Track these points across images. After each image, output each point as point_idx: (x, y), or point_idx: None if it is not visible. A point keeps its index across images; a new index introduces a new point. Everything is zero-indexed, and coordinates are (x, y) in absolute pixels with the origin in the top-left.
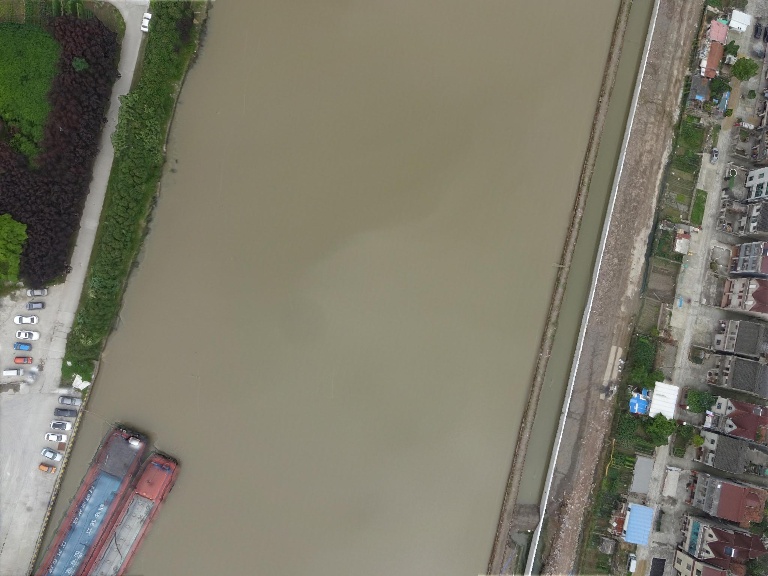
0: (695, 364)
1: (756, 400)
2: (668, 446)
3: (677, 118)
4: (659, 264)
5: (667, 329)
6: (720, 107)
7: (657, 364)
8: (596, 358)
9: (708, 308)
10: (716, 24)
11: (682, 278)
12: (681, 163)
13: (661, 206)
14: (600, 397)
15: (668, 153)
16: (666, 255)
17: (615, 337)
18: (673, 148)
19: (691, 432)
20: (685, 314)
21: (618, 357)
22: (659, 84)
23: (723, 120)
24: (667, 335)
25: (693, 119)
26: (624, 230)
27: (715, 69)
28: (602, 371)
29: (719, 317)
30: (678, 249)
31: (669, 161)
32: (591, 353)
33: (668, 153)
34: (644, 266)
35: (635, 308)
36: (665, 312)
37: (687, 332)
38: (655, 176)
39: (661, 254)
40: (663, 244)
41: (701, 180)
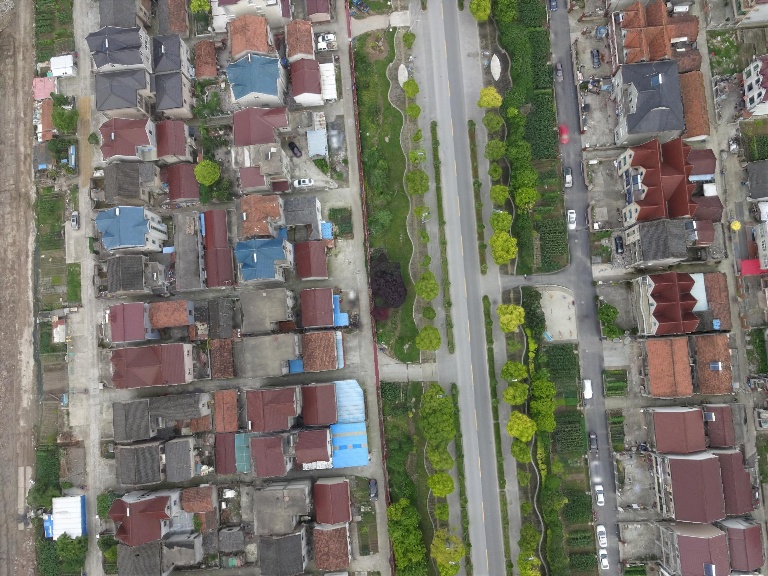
0: (112, 459)
1: (203, 477)
2: (101, 563)
3: (35, 195)
4: (49, 361)
5: (68, 431)
6: (69, 166)
7: (59, 475)
8: (5, 486)
9: (113, 391)
10: (39, 81)
11: (72, 368)
12: (46, 243)
13: (39, 296)
14: (19, 528)
15: (34, 237)
16: (49, 349)
17: (20, 457)
18: (38, 229)
19: (111, 543)
20: (85, 407)
21: (28, 478)
22: (7, 169)
23: (80, 177)
24: (64, 439)
25: (51, 189)
26: (6, 337)
27: (50, 129)
28: (15, 499)
29: (129, 396)
30: (57, 339)
31: (37, 245)
32: (0, 482)
33: (34, 237)
34: (35, 368)
35: (35, 418)
36: (61, 413)
37: (92, 427)
38: (25, 267)
39: (44, 350)
40: (46, 338)
41: (70, 252)
